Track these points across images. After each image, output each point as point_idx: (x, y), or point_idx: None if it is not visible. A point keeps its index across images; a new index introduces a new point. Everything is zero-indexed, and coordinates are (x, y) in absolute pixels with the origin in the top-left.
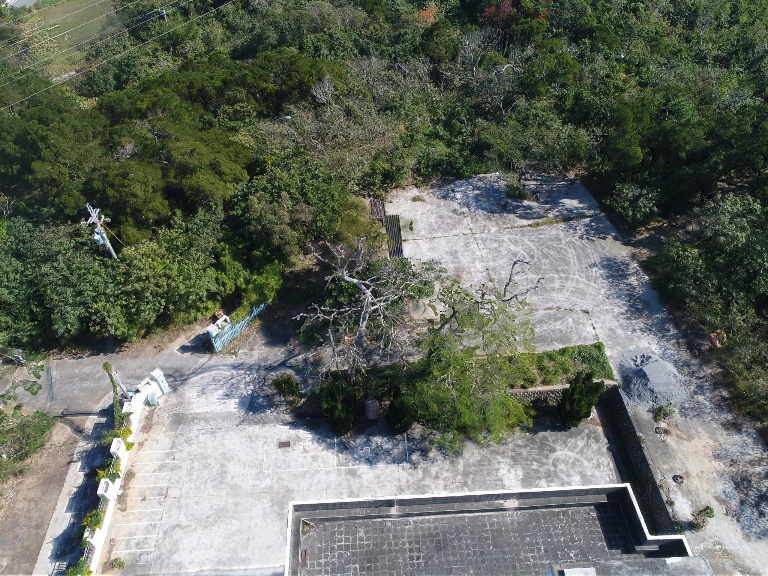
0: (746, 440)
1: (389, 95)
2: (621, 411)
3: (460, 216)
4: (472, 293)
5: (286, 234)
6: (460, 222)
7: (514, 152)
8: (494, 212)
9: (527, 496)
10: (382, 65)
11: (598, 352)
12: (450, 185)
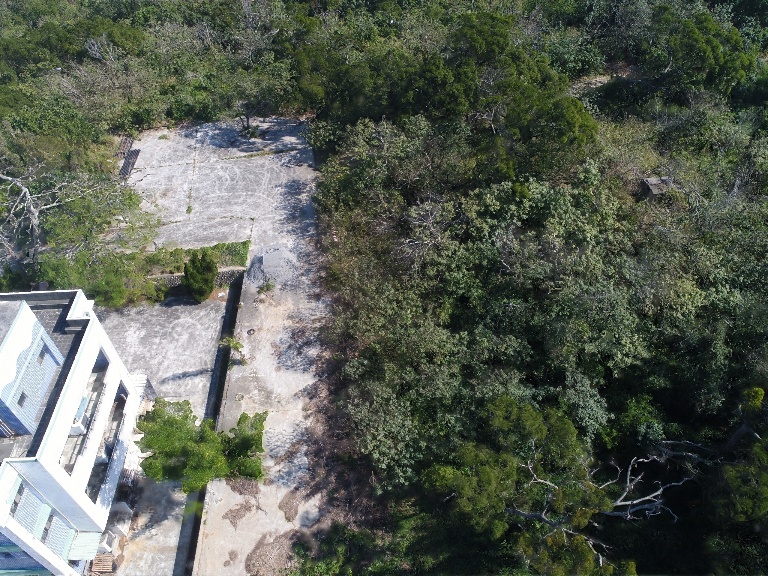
0: (320, 305)
1: (169, 54)
2: (241, 289)
3: (191, 150)
4: (169, 207)
5: (9, 156)
6: (189, 154)
7: (233, 94)
8: (222, 147)
9: (9, 299)
10: (176, 29)
11: (243, 247)
12: (197, 127)
